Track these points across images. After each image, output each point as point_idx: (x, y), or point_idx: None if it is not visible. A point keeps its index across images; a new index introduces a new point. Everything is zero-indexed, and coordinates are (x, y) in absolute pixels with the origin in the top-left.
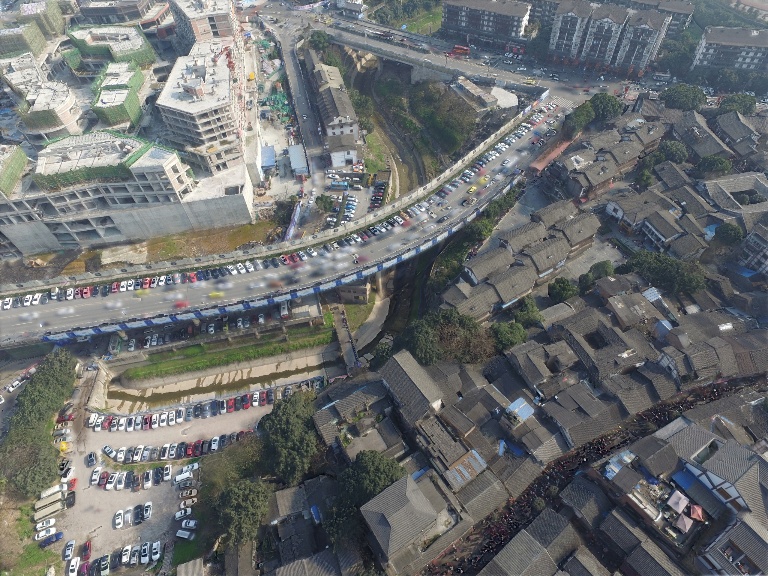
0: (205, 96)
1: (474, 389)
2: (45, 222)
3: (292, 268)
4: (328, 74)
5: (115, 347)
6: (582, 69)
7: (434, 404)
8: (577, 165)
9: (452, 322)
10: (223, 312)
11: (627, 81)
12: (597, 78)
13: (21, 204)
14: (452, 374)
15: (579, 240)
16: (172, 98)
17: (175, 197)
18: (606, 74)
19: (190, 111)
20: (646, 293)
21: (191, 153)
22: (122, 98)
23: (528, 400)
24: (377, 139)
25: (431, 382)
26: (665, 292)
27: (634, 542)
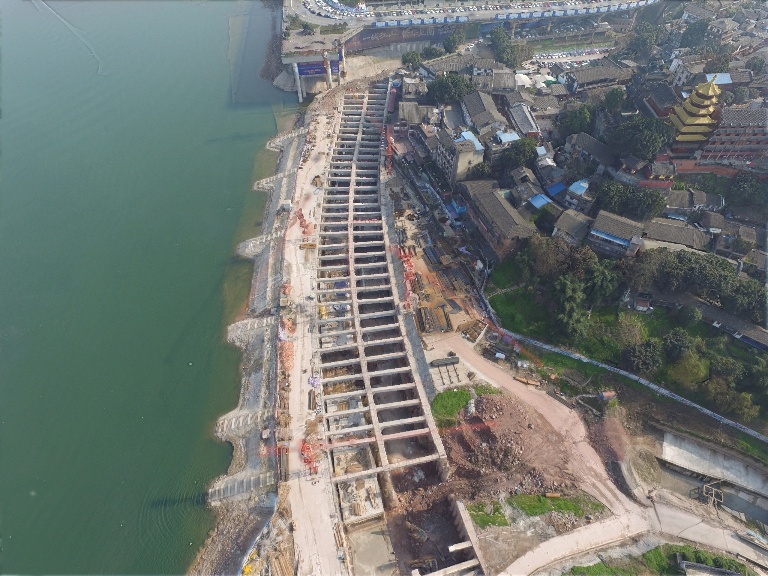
0: None
1: None
2: None
3: (598, 4)
4: None
5: None
6: None
7: None
8: None
9: None
10: (575, 14)
11: None
12: None
13: None
14: None
15: None
16: None
17: None
18: None
19: None
20: None
21: None
22: None
23: None
24: None
25: None
26: None
27: None
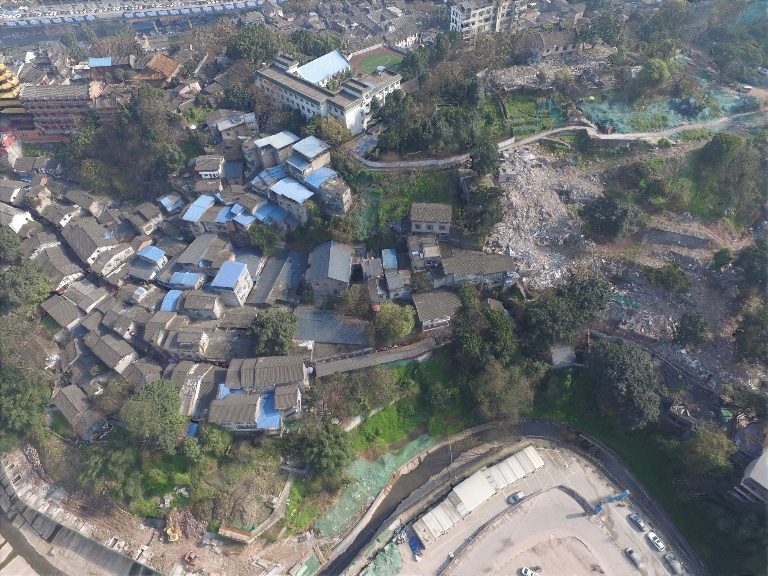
0: None
1: None
2: None
3: (237, 2)
4: None
5: (153, 32)
6: None
7: (279, 13)
8: None
9: None
10: (202, 11)
11: None
12: None
13: None
14: (292, 13)
15: None
16: None
17: None
18: None
19: None
20: None
21: None
22: None
23: (320, 19)
24: None
25: None
26: None
27: None
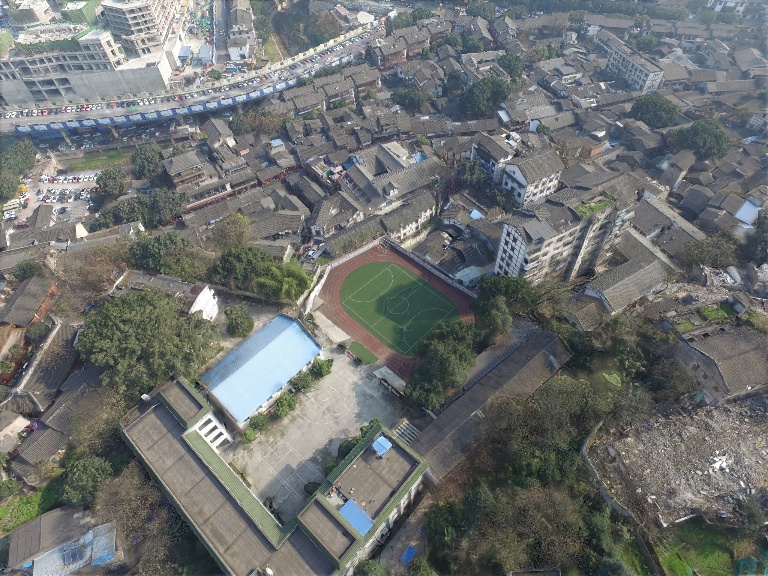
0: (134, 0)
1: (261, 143)
2: (24, 80)
3: (179, 102)
4: (240, 2)
5: (62, 146)
6: (432, 1)
7: (228, 141)
8: (379, 44)
9: (256, 111)
10: (128, 120)
11: (459, 7)
12: (438, 5)
13: (8, 64)
14: (248, 135)
15: (362, 83)
16: (112, 2)
17: (111, 66)
18: (447, 3)
19: (122, 8)
20: (392, 108)
21: (125, 40)
22: (82, 6)
23: (288, 146)
24: (275, 50)
25: (229, 130)
26: (405, 108)
27: None
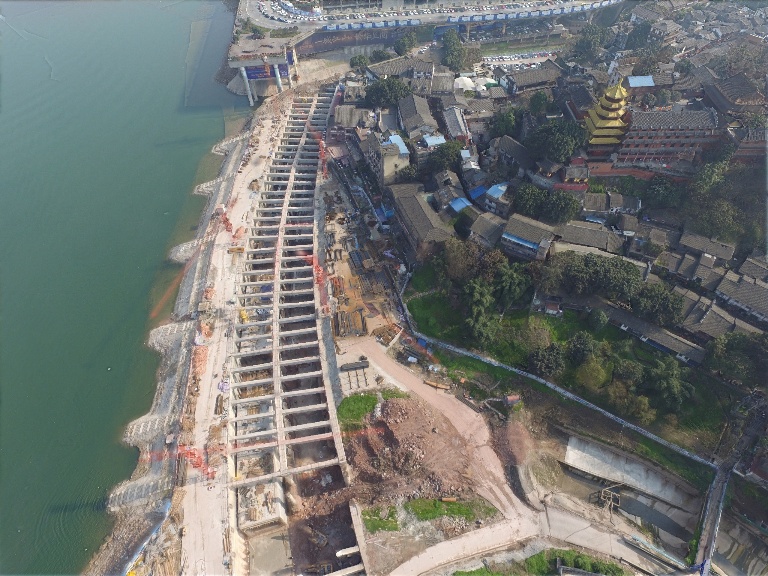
0: None
1: None
2: None
3: (553, 6)
4: None
5: (467, 38)
6: None
7: None
8: None
9: (656, 5)
10: (529, 16)
11: None
12: None
13: None
14: None
15: None
16: None
17: None
18: None
19: None
20: (742, 9)
21: None
22: None
23: None
24: None
25: None
26: None
27: (754, 46)
